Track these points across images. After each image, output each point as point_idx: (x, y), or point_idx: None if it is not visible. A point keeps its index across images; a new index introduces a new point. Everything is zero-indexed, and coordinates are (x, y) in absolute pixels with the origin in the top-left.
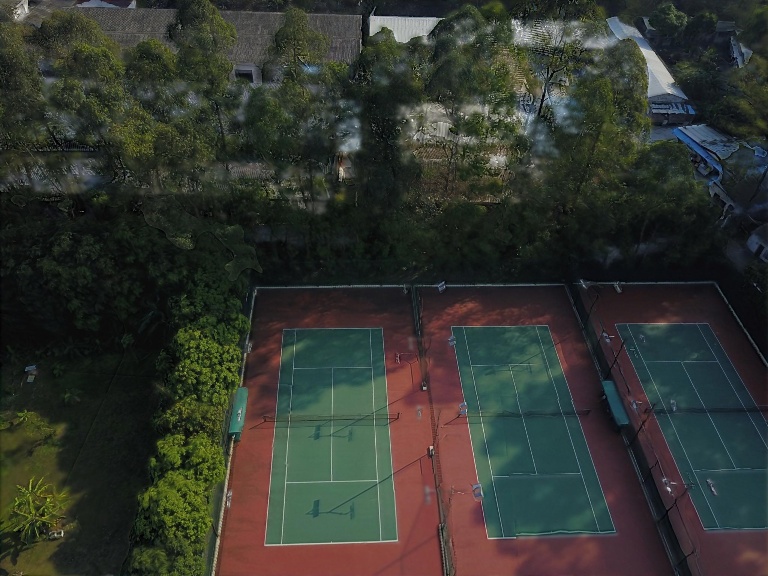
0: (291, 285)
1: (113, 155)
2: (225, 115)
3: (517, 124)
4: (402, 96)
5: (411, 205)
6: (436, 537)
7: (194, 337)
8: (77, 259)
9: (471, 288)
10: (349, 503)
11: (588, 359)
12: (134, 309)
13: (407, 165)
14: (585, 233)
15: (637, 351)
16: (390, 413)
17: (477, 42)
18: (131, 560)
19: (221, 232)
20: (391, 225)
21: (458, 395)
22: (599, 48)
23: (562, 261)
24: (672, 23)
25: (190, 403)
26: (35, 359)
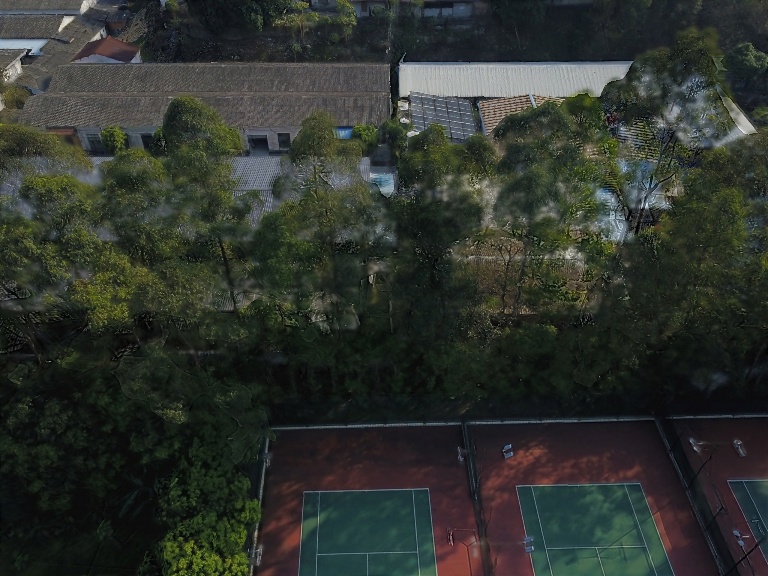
0: (313, 424)
1: None
2: None
3: (606, 244)
4: (457, 221)
5: (462, 329)
6: None
7: (185, 553)
8: (38, 435)
9: (537, 425)
10: None
11: (699, 538)
12: (114, 485)
13: (459, 291)
14: (684, 362)
15: (761, 523)
16: None
17: (558, 149)
18: None
19: (221, 399)
20: (438, 360)
21: None
22: (719, 147)
23: (651, 390)
24: (751, 65)
25: None
26: None
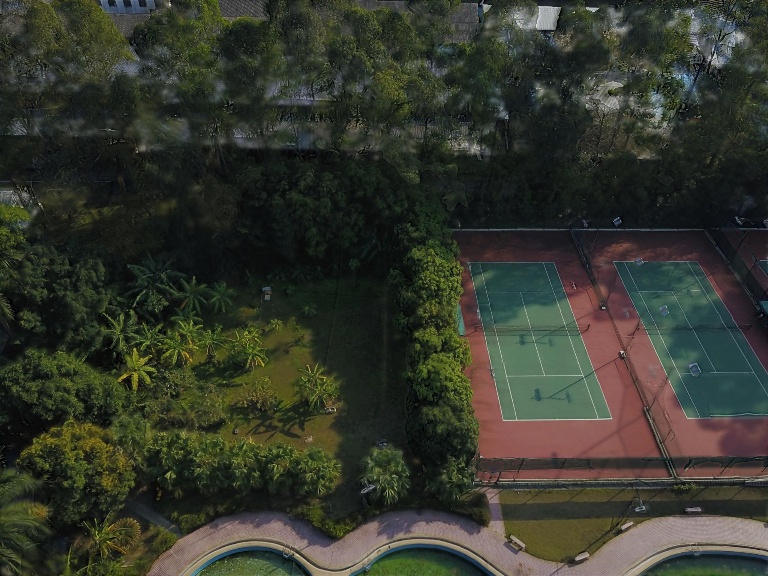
0: (465, 228)
1: (350, 105)
2: (439, 73)
3: (687, 81)
4: (599, 54)
5: (575, 157)
6: (643, 417)
7: (430, 253)
8: (321, 192)
9: (622, 232)
10: (564, 391)
11: (739, 287)
12: (356, 238)
13: (584, 118)
14: (728, 182)
15: None
16: (579, 326)
17: (665, 8)
18: (422, 416)
19: (442, 169)
20: (563, 172)
21: (634, 313)
22: (763, 15)
23: (702, 209)
24: None
25: (435, 305)
26: (266, 282)
